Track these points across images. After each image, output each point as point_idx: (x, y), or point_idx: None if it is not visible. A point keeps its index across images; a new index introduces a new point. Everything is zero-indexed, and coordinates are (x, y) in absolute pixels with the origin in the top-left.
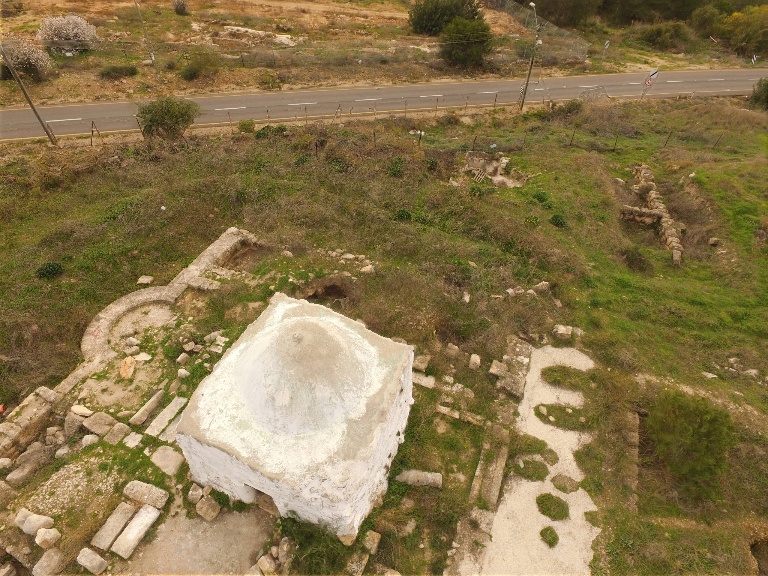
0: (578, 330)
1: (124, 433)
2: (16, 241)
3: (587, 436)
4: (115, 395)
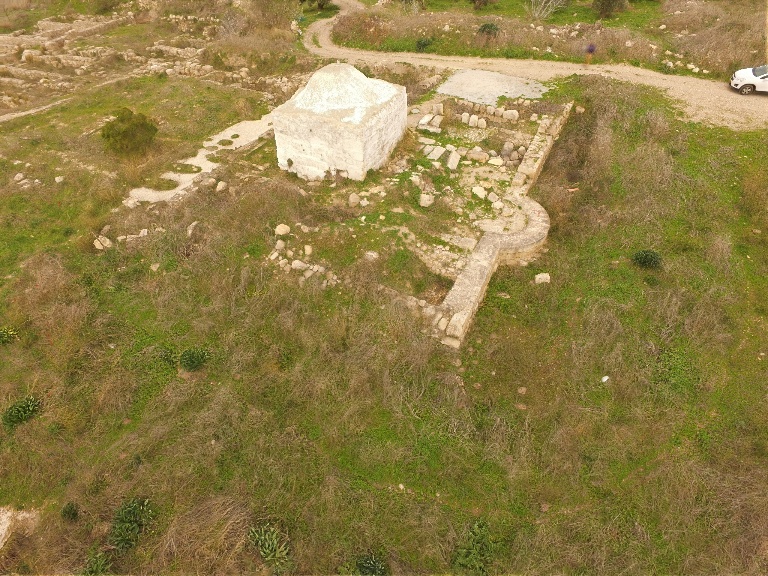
0: (115, 211)
1: None
2: (765, 316)
3: (180, 162)
4: (481, 169)
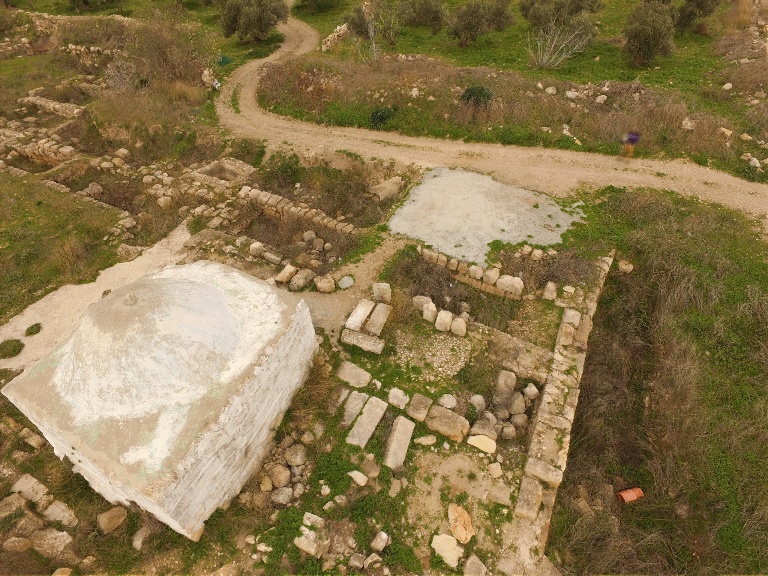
0: None
1: (411, 405)
2: None
3: None
4: (452, 467)
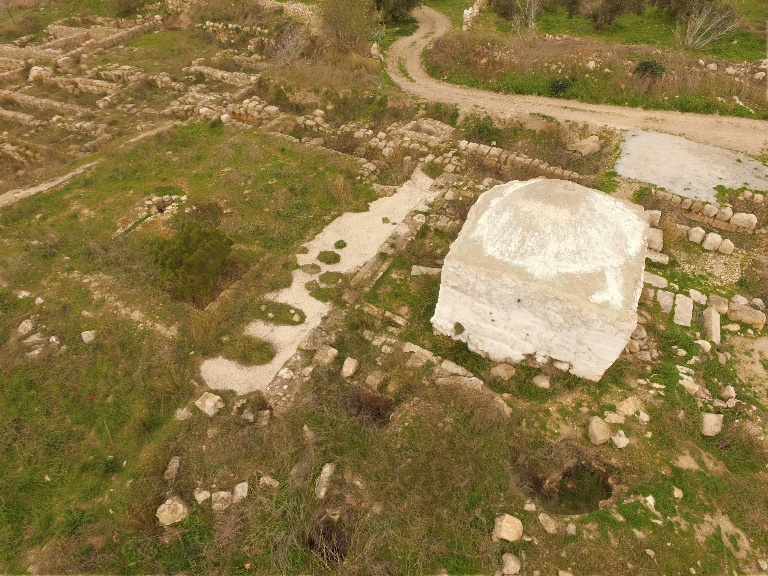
0: (182, 414)
1: (712, 301)
2: None
3: (268, 297)
4: (764, 345)
